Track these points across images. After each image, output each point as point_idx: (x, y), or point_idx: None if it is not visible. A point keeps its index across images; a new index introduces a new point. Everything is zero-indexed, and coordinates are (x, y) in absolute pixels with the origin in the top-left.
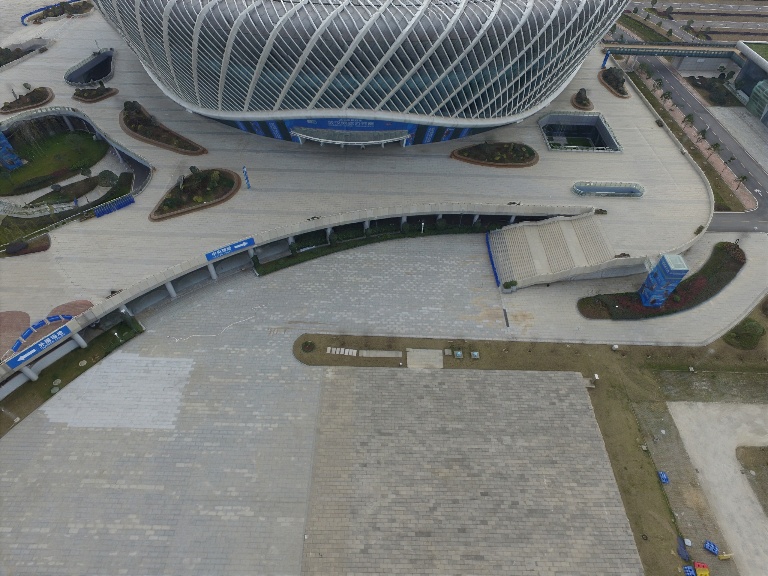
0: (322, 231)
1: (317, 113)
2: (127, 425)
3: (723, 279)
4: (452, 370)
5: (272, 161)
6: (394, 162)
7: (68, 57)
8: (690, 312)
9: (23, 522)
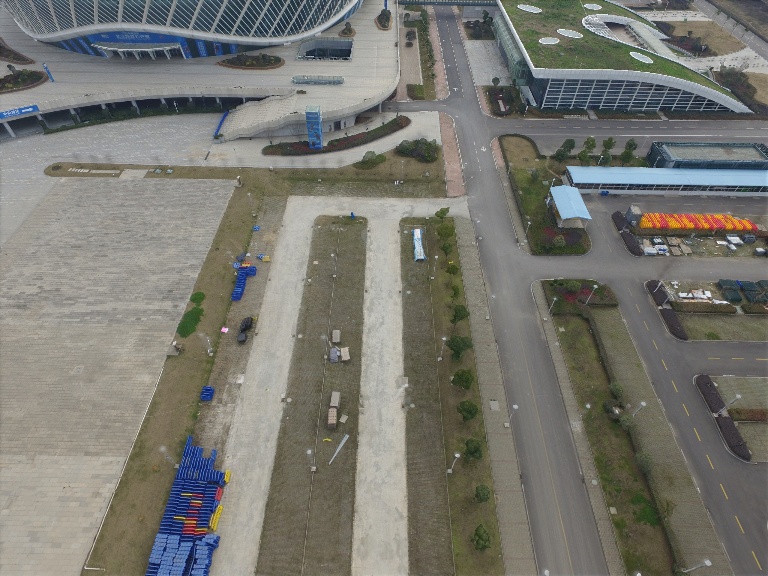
0: None
1: (101, 26)
2: None
3: (378, 134)
4: (148, 178)
5: (80, 67)
6: (171, 67)
7: None
8: (341, 152)
9: None
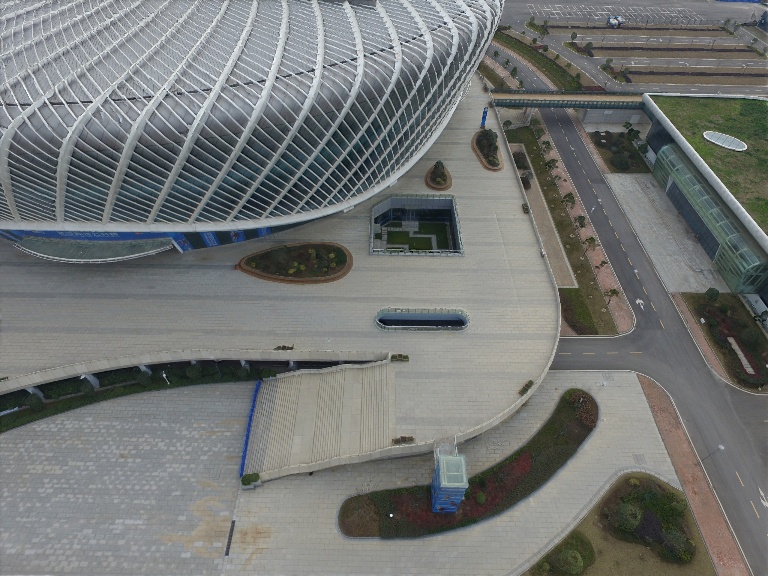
0: None
1: (28, 227)
2: None
3: (555, 460)
4: None
5: None
6: (157, 278)
7: None
8: (496, 520)
9: None
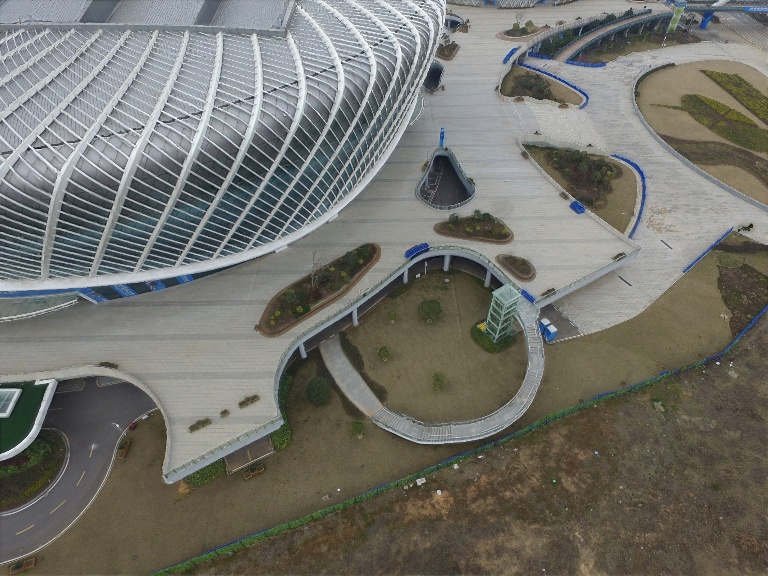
0: None
1: None
2: None
3: None
4: None
5: None
6: None
7: (466, 85)
8: None
9: None
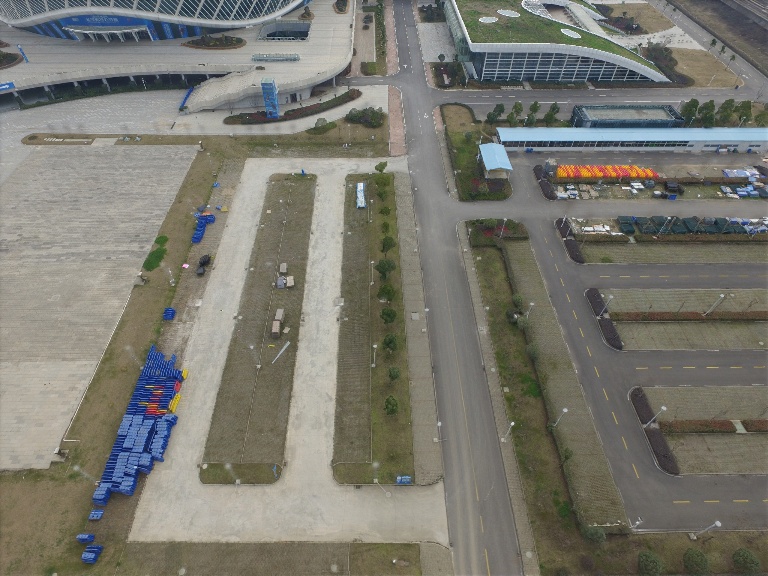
0: None
1: (72, 10)
2: None
3: (330, 104)
4: (118, 145)
5: (53, 49)
6: (139, 48)
7: None
8: (296, 120)
9: None
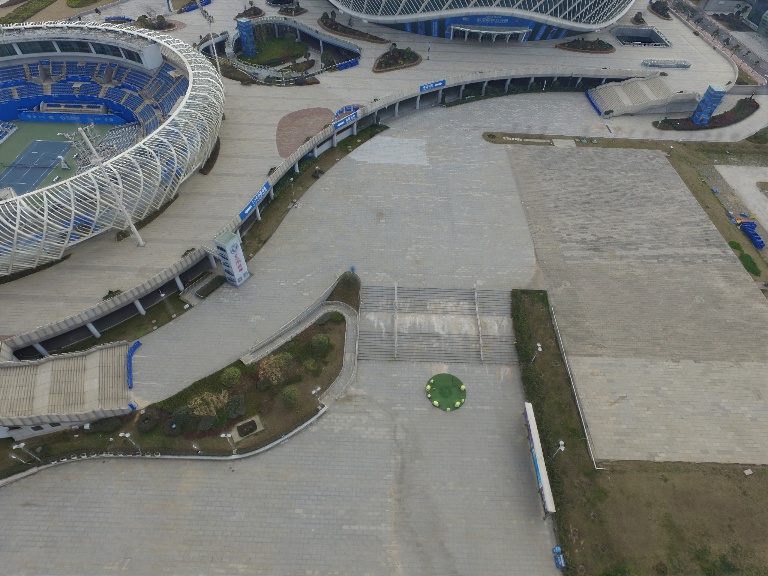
0: (477, 88)
1: (474, 10)
2: (402, 163)
3: (745, 113)
4: (583, 147)
5: (436, 47)
6: (518, 49)
7: None
8: (725, 128)
9: (367, 194)
